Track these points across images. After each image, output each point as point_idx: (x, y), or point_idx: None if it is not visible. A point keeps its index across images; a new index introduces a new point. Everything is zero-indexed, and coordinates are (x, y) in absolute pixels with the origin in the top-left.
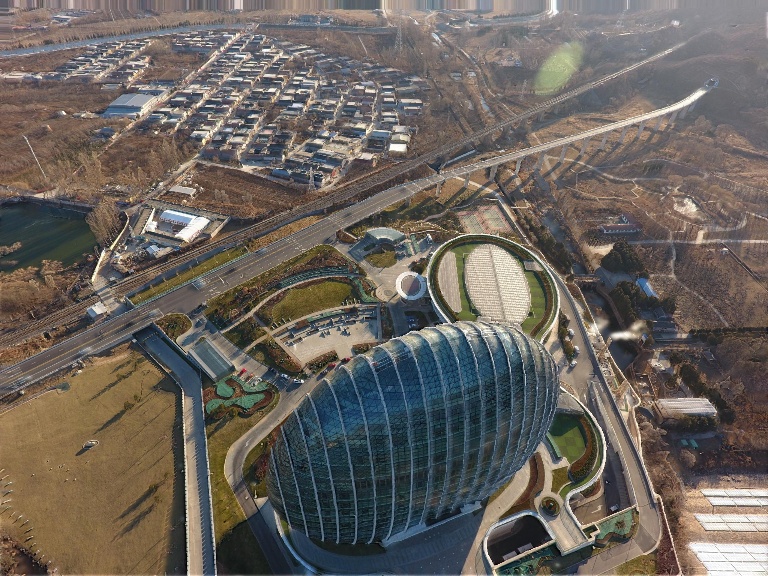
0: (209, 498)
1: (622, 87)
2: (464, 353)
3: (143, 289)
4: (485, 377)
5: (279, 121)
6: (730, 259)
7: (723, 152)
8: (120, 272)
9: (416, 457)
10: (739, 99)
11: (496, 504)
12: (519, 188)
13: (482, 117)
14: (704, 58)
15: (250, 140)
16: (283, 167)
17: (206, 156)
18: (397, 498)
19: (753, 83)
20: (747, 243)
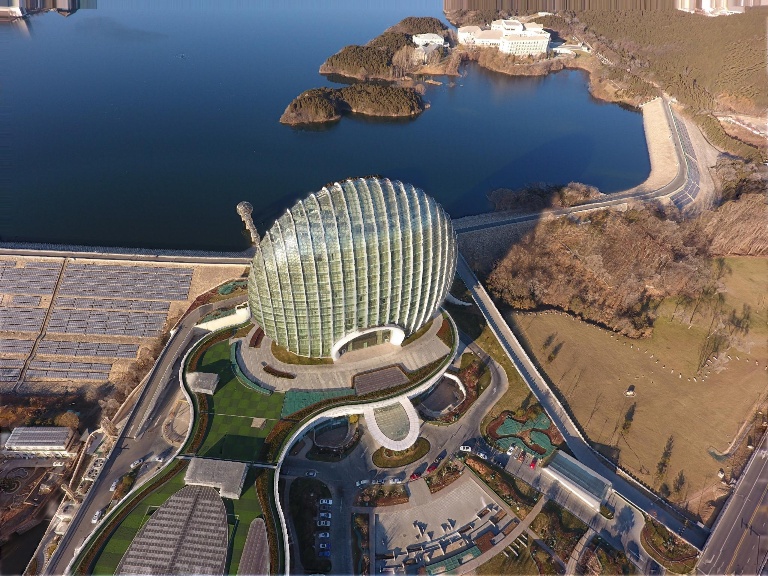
0: None
1: None
2: None
3: None
4: None
5: None
6: None
7: None
8: None
9: None
10: None
11: None
12: None
13: None
14: None
15: None
16: None
17: None
18: None
19: None
20: None
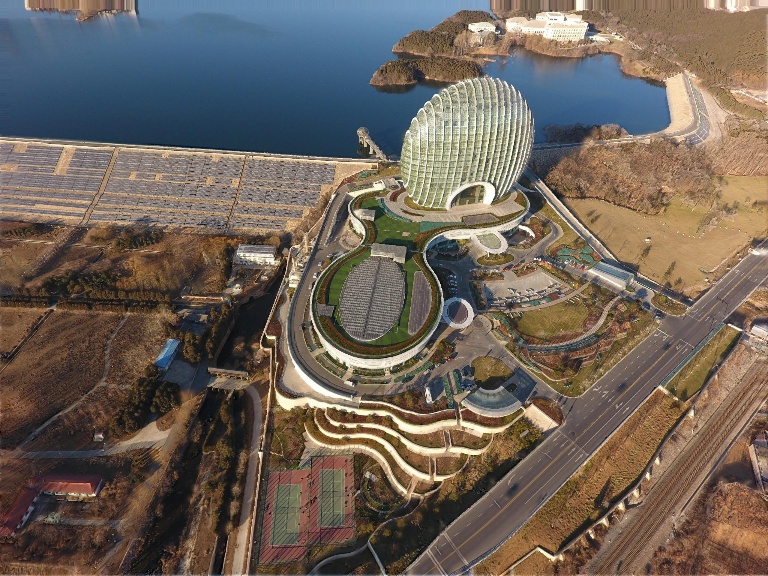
0: None
1: None
2: None
3: None
4: None
5: None
6: None
7: None
8: None
9: None
10: None
11: None
12: None
13: None
14: None
15: None
16: None
17: None
18: None
19: None
20: None
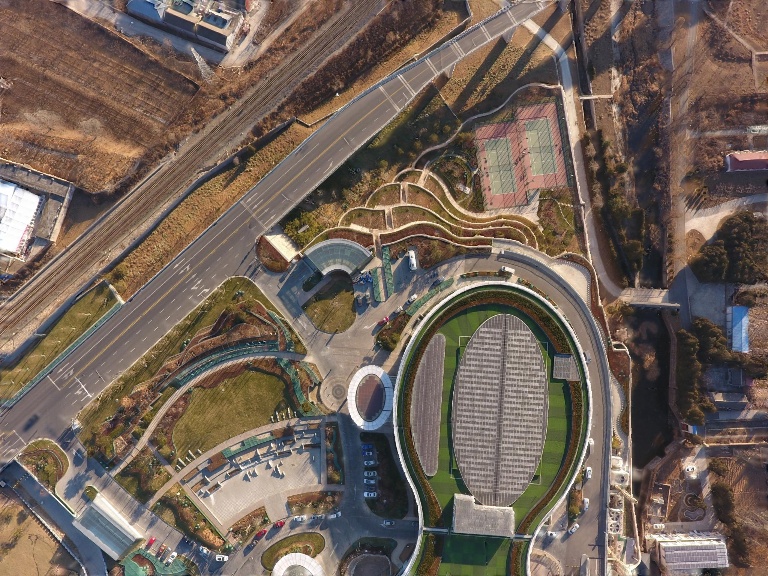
0: None
1: None
2: None
3: None
4: None
5: None
6: None
7: None
8: None
9: None
10: None
11: None
12: (611, 28)
13: None
14: None
15: None
16: None
17: None
18: None
19: None
20: None
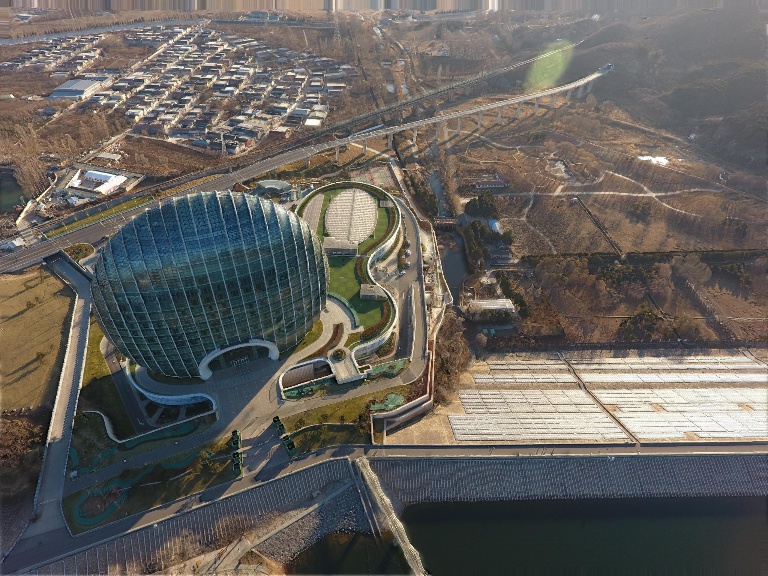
0: (82, 360)
1: (531, 72)
2: (212, 204)
3: (57, 227)
4: (229, 221)
5: (210, 102)
6: (577, 206)
7: (604, 125)
8: (42, 217)
9: (183, 277)
10: (630, 80)
11: (298, 354)
12: (413, 154)
13: (399, 98)
14: (605, 45)
15: (180, 117)
16: (204, 138)
17: (136, 130)
18: (180, 314)
19: (644, 66)
20: (597, 194)
